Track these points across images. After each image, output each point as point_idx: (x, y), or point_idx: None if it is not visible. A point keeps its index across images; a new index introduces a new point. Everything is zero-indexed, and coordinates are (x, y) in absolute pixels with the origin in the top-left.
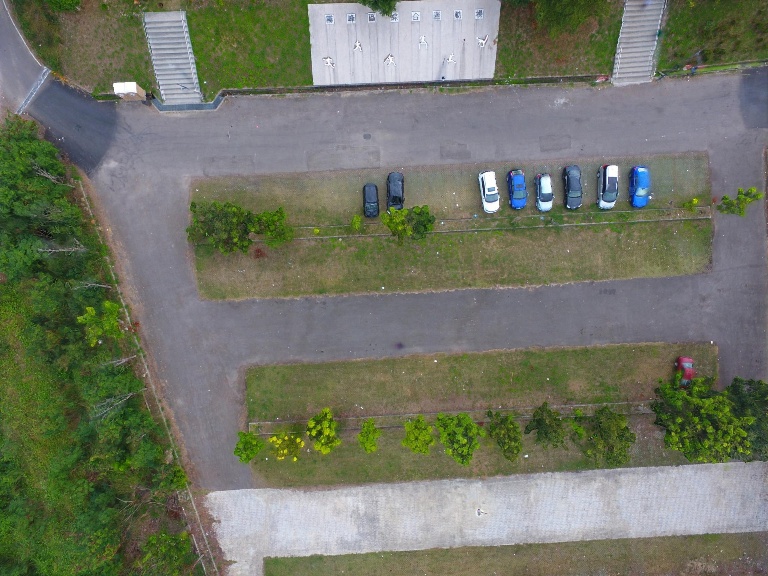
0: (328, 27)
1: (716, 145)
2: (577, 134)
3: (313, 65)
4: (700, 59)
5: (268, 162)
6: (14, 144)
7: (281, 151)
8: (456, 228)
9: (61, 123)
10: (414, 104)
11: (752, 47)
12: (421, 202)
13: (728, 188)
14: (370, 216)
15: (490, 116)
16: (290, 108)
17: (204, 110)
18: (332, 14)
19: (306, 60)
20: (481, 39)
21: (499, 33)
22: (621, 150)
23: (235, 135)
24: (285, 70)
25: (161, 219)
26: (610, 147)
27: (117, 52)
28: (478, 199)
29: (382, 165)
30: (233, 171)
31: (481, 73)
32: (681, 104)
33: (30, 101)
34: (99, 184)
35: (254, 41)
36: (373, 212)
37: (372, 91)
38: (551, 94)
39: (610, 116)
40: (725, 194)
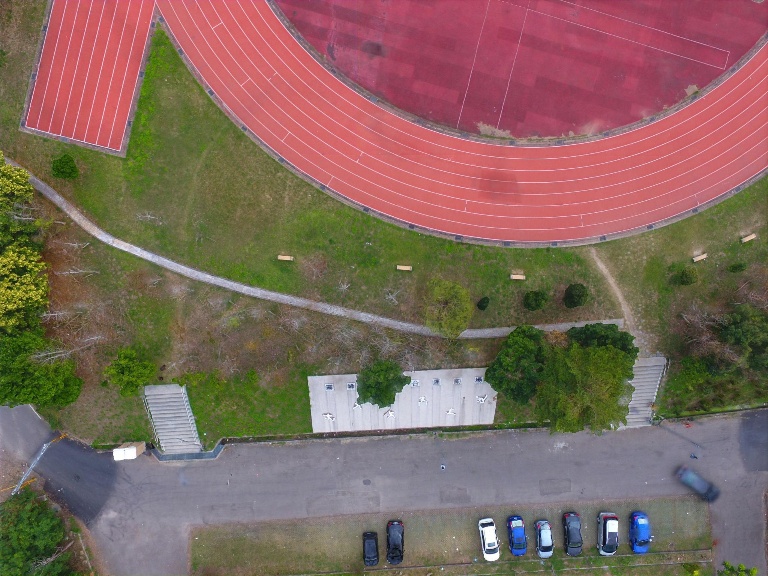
0: (328, 392)
1: (716, 488)
2: (577, 478)
3: (313, 419)
4: (699, 405)
5: (268, 509)
6: (13, 530)
7: (281, 498)
8: (456, 573)
9: (61, 474)
10: (414, 450)
11: (751, 396)
12: (421, 546)
13: (728, 531)
14: (370, 565)
15: (490, 461)
16: (290, 455)
17: (204, 459)
18: (332, 383)
19: (306, 416)
20: (481, 397)
21: (498, 392)
22: (621, 493)
23: (235, 483)
24: (285, 423)
25: (160, 568)
26: (610, 490)
27: (117, 415)
28: (478, 543)
29: (382, 510)
30: (233, 519)
31: (481, 420)
32: (681, 447)
33: (30, 453)
34: (98, 534)
35: (254, 403)
36: (373, 563)
37: (372, 437)
38: (551, 438)
39: (610, 460)
40: (725, 537)
